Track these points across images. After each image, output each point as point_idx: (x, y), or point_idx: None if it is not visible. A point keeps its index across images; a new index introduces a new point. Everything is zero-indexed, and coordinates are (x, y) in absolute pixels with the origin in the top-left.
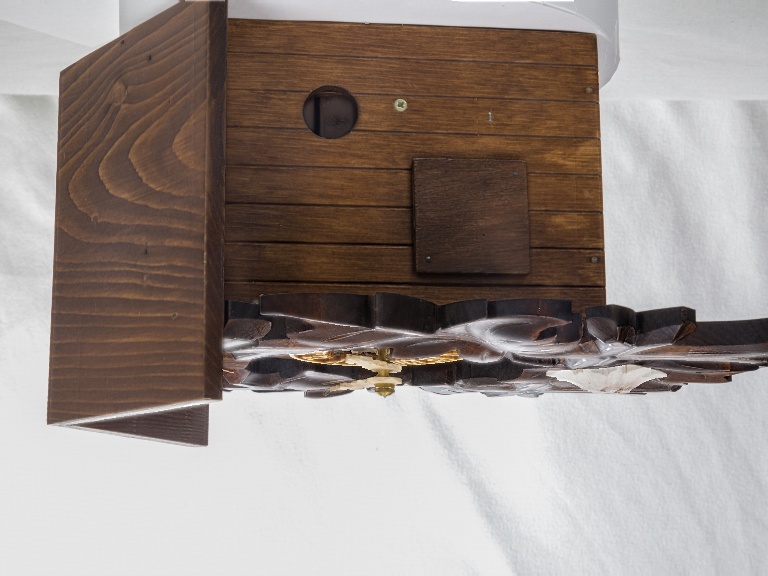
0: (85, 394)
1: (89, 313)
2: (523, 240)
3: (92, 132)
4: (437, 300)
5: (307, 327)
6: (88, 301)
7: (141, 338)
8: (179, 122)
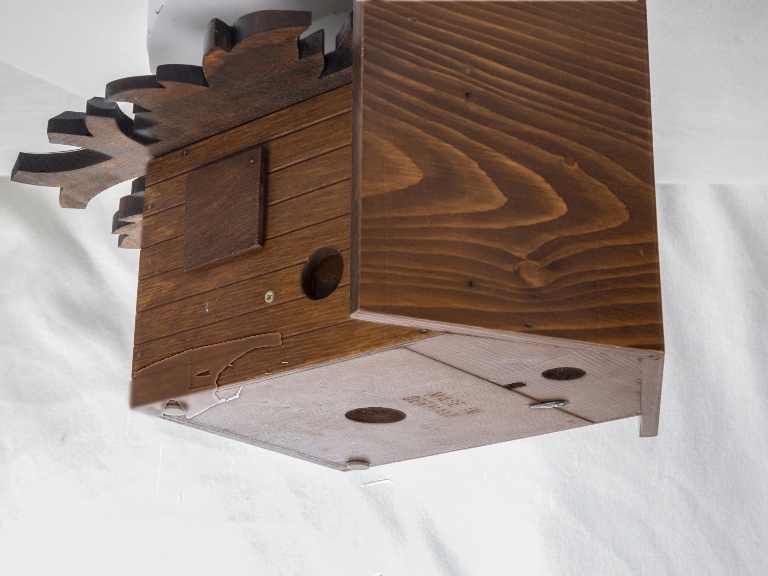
0: (572, 4)
1: (572, 76)
2: (189, 201)
3: (584, 254)
4: (254, 134)
5: (306, 40)
6: (575, 87)
7: (472, 20)
8: (411, 194)
